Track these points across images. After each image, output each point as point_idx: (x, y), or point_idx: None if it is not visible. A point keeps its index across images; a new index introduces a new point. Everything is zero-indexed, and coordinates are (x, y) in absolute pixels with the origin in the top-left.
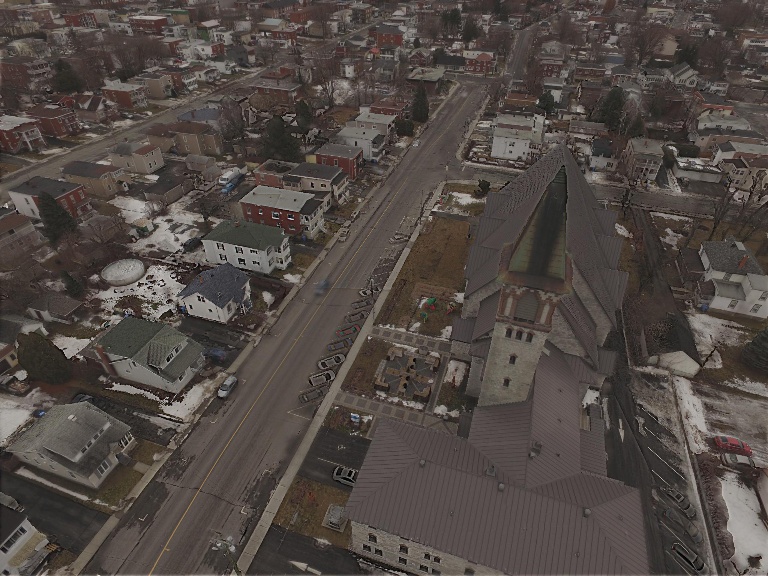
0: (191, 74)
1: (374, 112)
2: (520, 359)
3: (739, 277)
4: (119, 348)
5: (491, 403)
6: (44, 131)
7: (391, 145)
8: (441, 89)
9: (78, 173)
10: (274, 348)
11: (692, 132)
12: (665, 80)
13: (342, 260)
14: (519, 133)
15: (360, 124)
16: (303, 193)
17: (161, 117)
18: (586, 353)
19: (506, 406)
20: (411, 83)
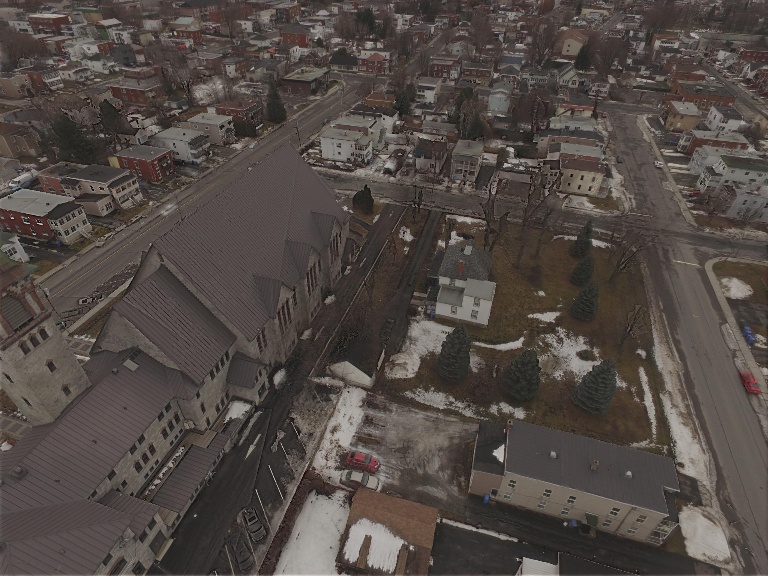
0: (53, 73)
1: (219, 112)
2: (12, 378)
3: (462, 282)
4: None
5: (37, 423)
6: None
7: (226, 146)
8: (319, 89)
9: None
10: None
11: (538, 133)
12: (555, 80)
13: (86, 266)
14: (349, 134)
15: (193, 125)
16: (63, 197)
17: (2, 118)
18: (180, 367)
19: (45, 426)
20: (286, 83)
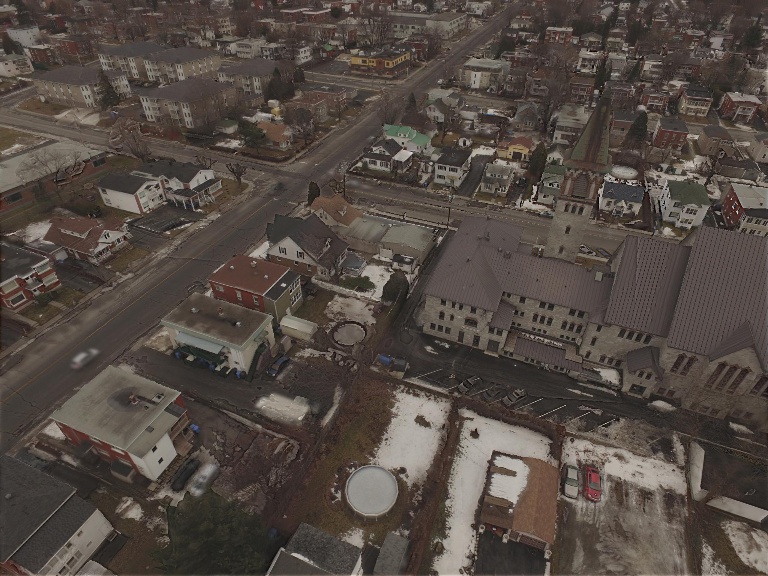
0: None
1: None
2: None
3: None
4: (549, 169)
5: None
6: (765, 116)
7: None
8: None
9: (707, 131)
10: (587, 228)
11: None
12: None
13: None
14: None
15: None
16: None
17: None
18: None
19: None
20: None
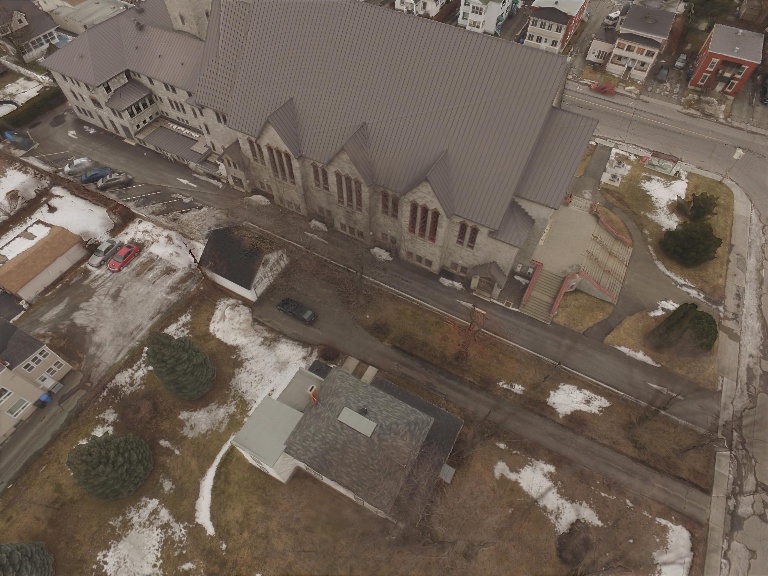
0: None
1: None
2: None
3: None
4: None
5: None
6: None
7: None
8: None
9: None
10: None
11: None
12: None
13: None
14: None
15: None
16: (577, 8)
17: None
18: None
19: None
20: None
